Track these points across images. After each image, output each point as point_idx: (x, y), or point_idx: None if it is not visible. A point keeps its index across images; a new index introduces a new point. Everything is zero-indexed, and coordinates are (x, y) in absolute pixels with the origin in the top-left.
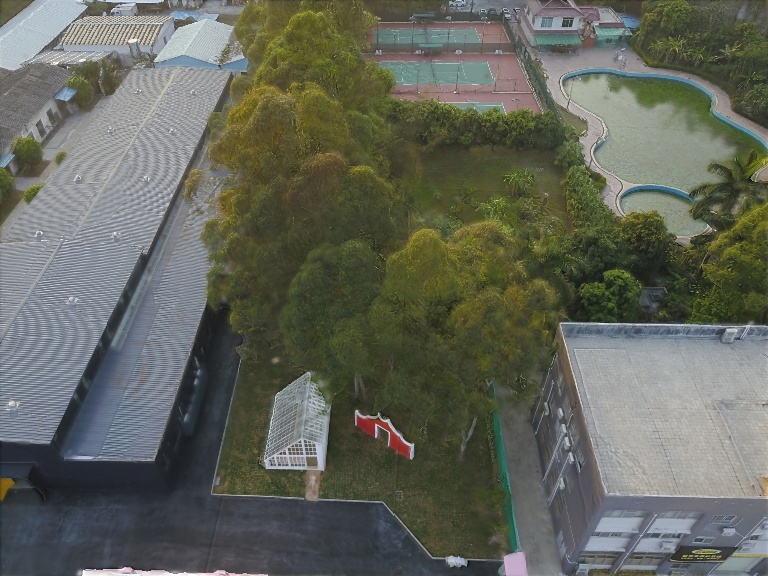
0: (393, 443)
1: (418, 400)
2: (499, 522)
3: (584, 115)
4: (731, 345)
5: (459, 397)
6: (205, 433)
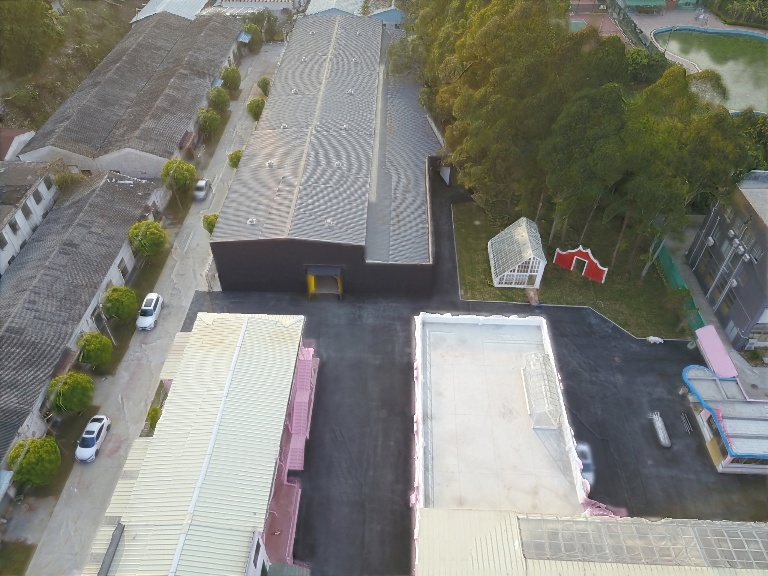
0: (588, 271)
1: (656, 195)
2: (681, 318)
3: (679, 60)
4: None
5: (681, 196)
6: (442, 264)
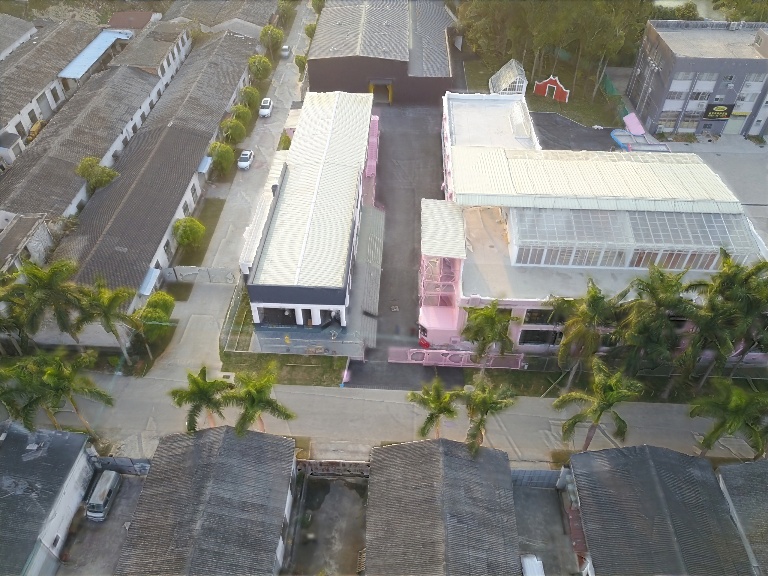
0: (556, 95)
1: (594, 18)
2: None
3: None
4: (734, 31)
5: None
6: (458, 91)
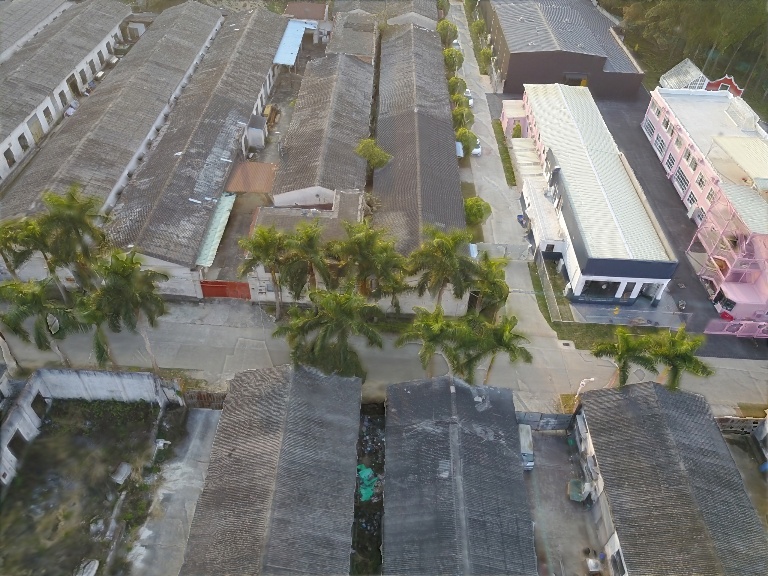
0: None
1: None
2: None
3: None
4: None
5: None
6: None
